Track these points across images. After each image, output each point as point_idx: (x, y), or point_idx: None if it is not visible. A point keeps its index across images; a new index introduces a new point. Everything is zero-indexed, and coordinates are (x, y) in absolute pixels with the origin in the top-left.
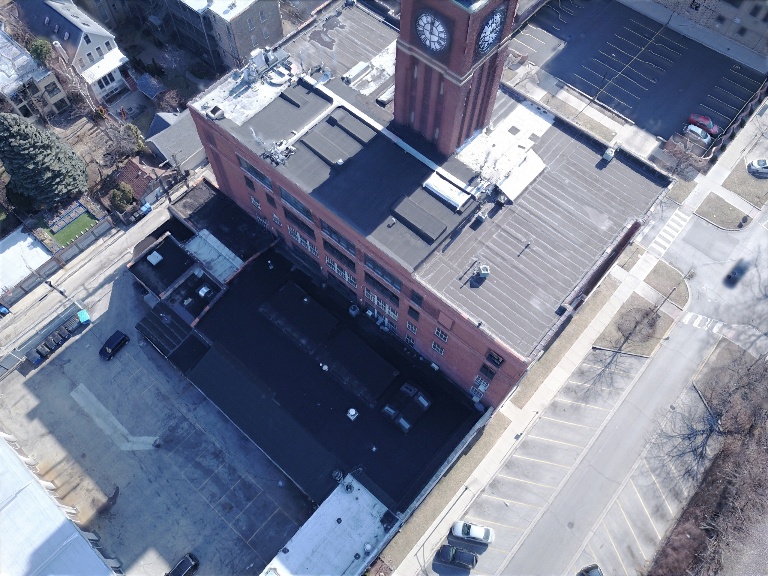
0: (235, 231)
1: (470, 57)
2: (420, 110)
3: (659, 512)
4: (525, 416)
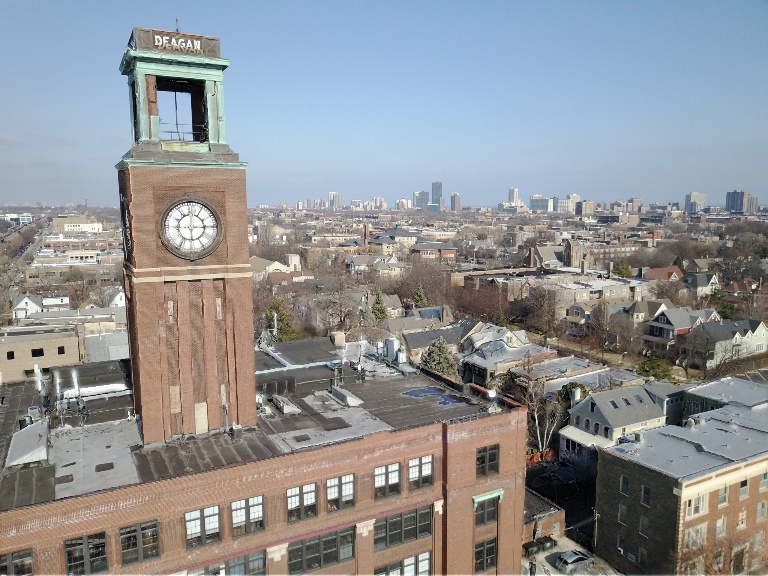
0: None
1: None
2: None
3: None
4: None
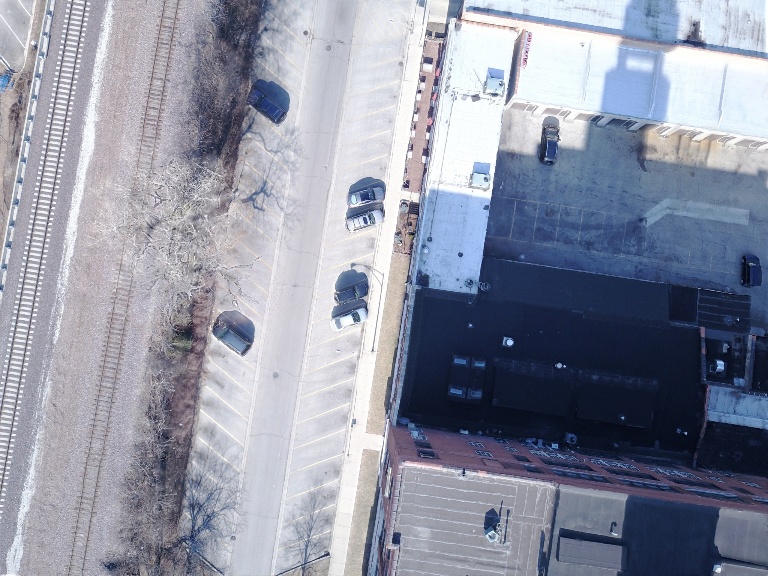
0: (742, 447)
1: None
2: None
3: (210, 432)
4: (357, 445)
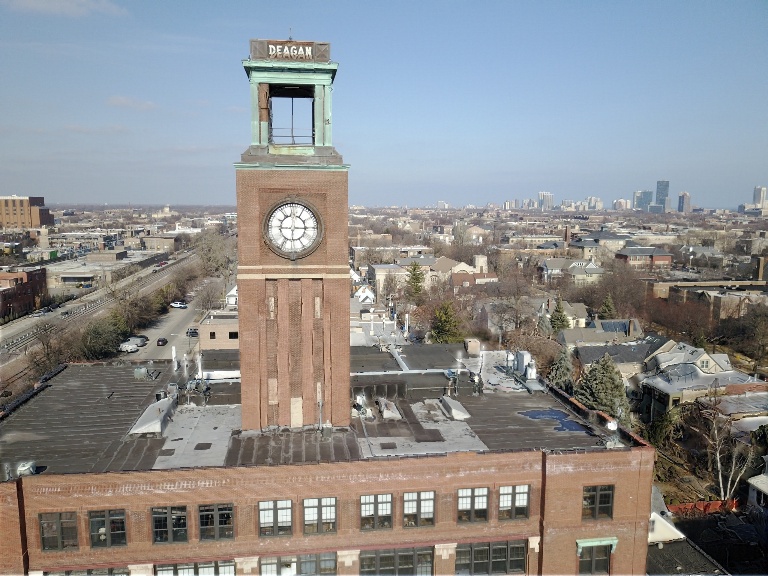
0: None
1: None
2: None
3: None
4: None
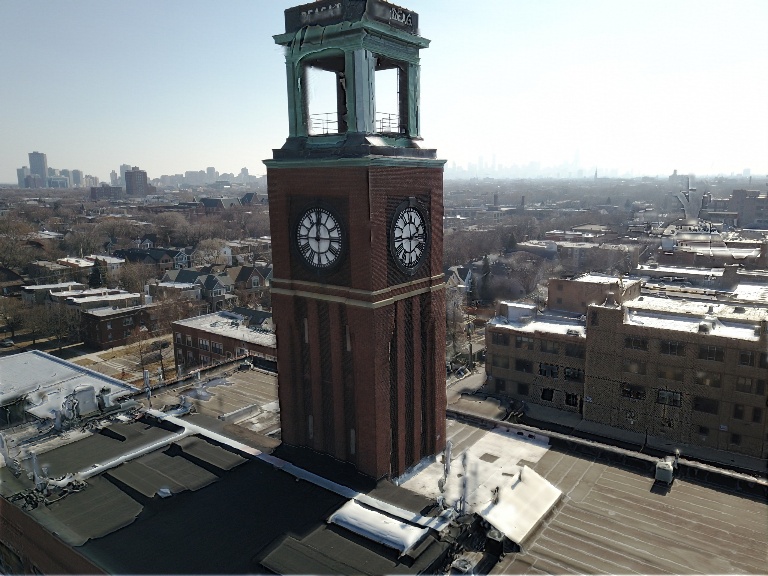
0: None
1: (383, 259)
2: (320, 402)
3: None
4: None
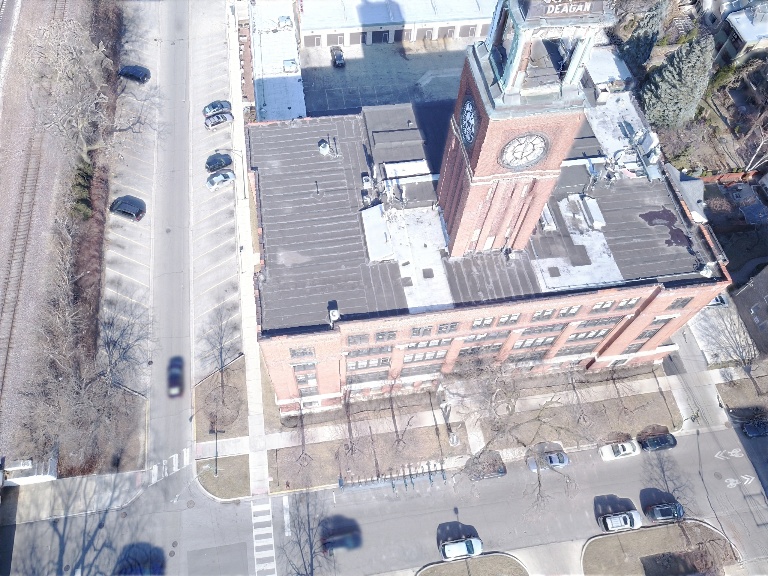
0: None
1: None
2: None
3: (117, 282)
4: (248, 264)
